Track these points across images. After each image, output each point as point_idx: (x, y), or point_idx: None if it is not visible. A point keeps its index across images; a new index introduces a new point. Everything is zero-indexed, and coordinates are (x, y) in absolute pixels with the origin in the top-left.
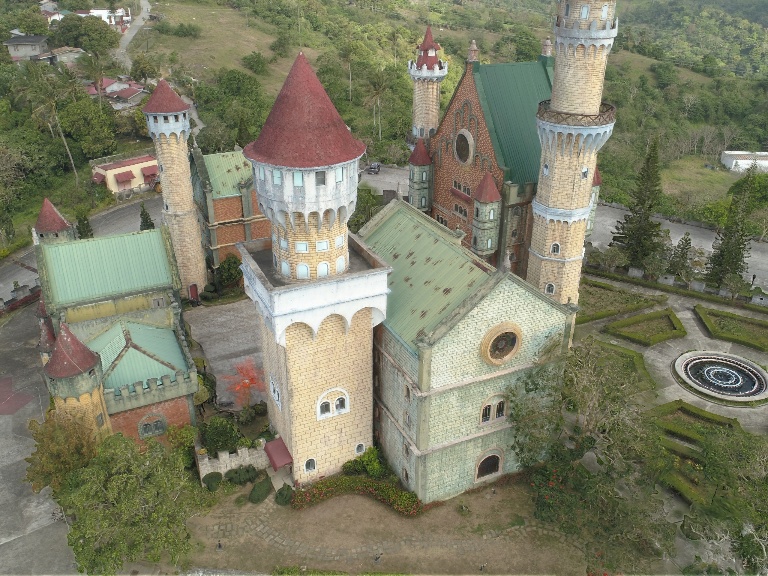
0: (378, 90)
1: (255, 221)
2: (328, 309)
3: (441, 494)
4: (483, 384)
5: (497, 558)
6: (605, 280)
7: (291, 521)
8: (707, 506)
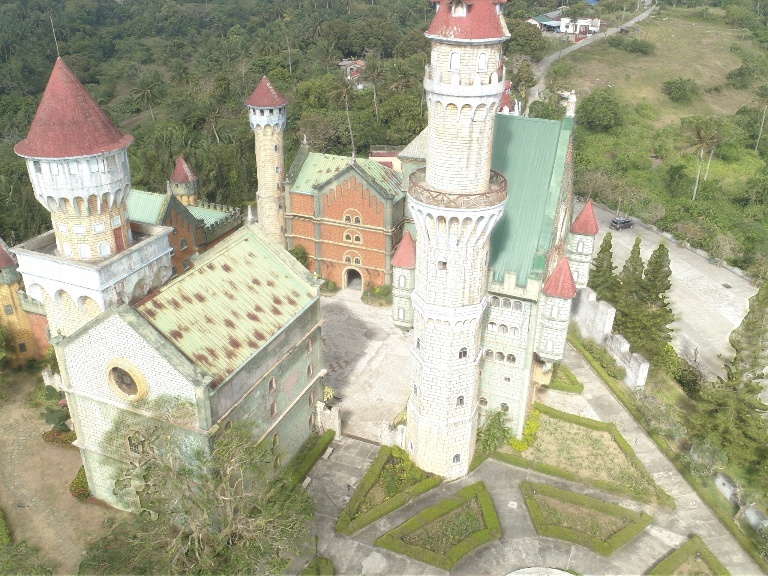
0: (702, 138)
1: (325, 223)
2: (58, 283)
3: (110, 498)
4: (122, 411)
5: (61, 571)
6: (649, 443)
7: (38, 447)
8: None
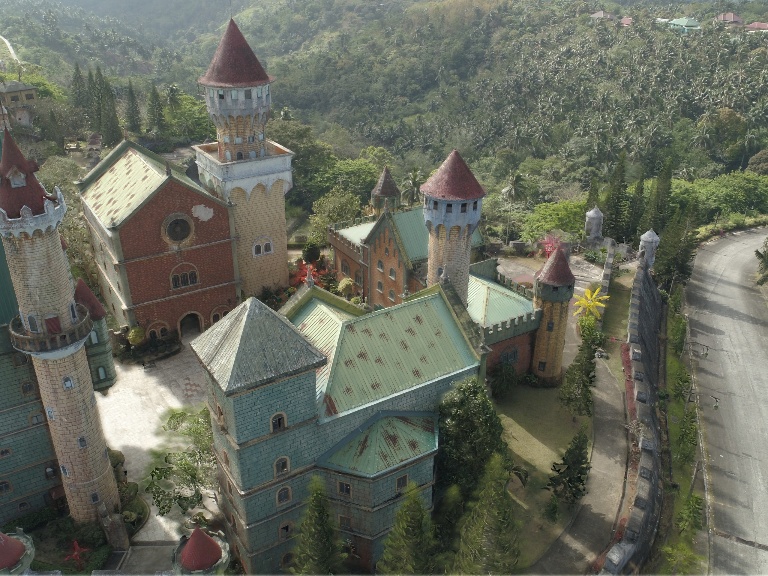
0: None
1: None
2: None
3: None
4: None
5: None
6: None
7: None
8: (84, 173)
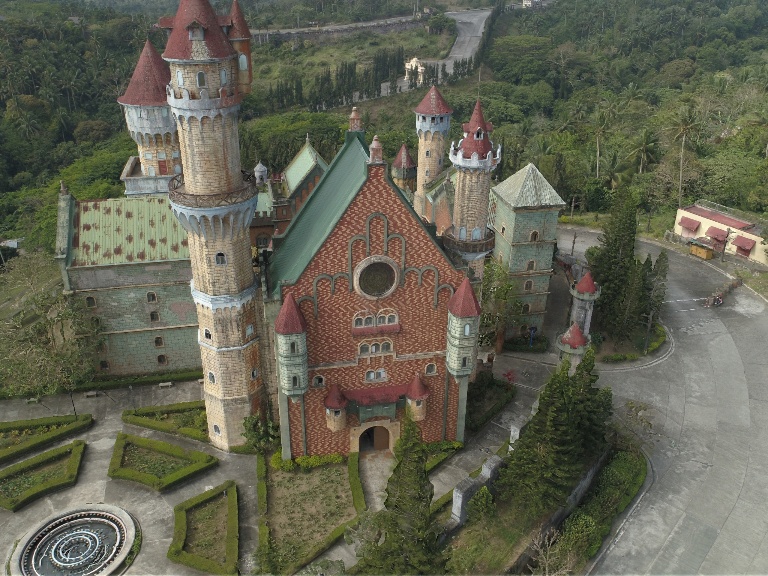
0: None
1: None
2: None
3: None
4: None
5: None
6: None
7: None
8: None
